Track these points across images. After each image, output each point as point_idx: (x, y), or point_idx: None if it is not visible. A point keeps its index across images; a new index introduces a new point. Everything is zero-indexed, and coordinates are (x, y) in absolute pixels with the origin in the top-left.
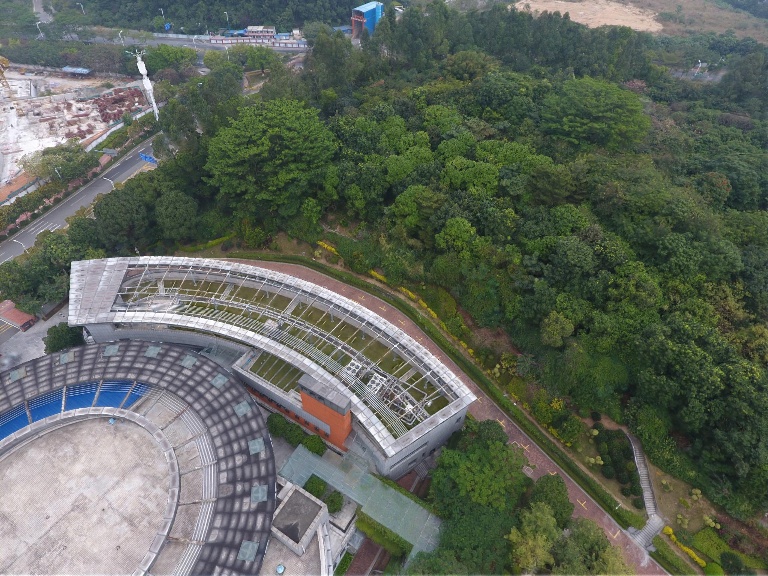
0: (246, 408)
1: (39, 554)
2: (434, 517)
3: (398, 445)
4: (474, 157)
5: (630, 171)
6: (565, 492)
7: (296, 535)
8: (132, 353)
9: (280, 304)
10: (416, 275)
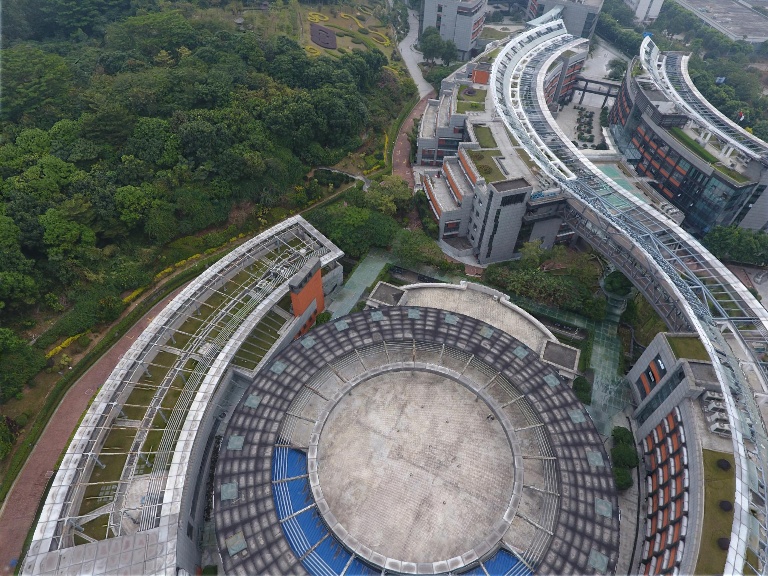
0: (307, 341)
1: (439, 464)
2: (369, 254)
3: (335, 250)
4: (14, 172)
5: (122, 81)
6: (357, 189)
7: (399, 294)
8: (235, 465)
9: (165, 362)
10: (151, 256)
